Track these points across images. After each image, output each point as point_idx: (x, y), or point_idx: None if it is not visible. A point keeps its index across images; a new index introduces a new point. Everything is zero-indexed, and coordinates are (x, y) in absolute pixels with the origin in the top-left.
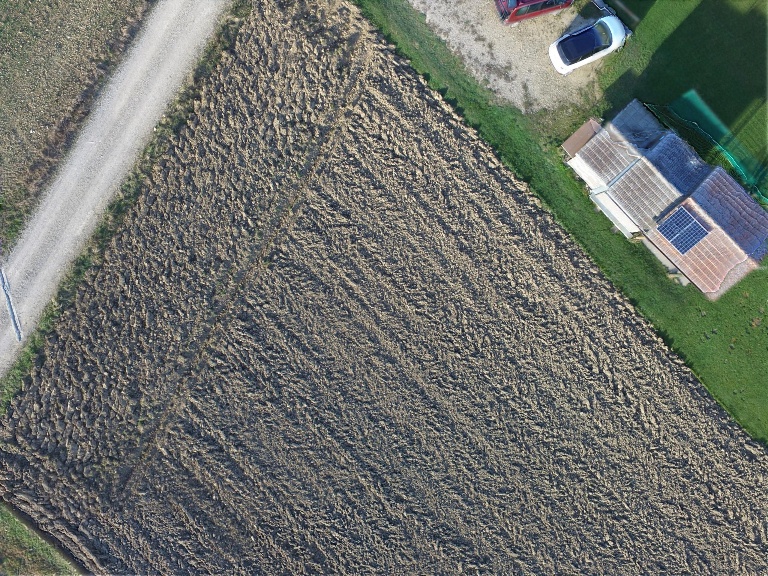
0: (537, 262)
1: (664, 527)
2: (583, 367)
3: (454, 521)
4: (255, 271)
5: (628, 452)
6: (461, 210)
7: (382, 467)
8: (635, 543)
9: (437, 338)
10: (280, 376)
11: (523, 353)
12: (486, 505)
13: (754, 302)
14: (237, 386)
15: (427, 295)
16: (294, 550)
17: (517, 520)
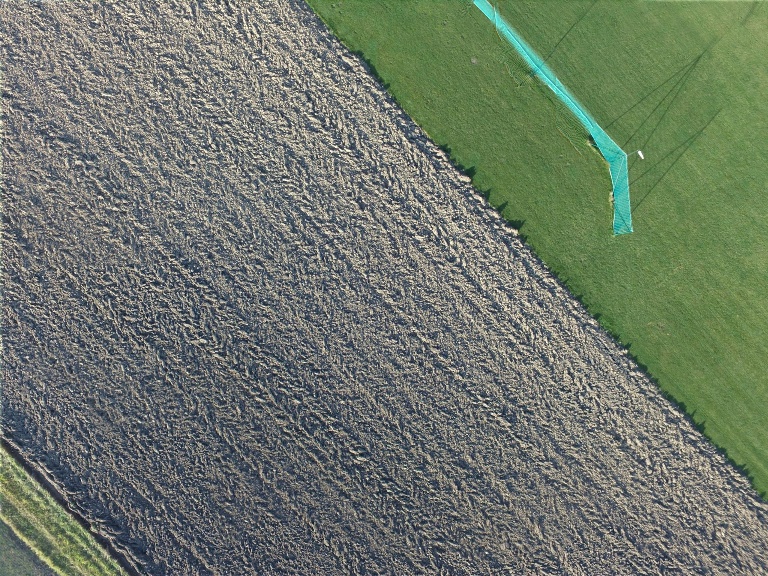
0: None
1: (265, 133)
2: None
3: (62, 120)
4: None
5: (231, 61)
6: None
7: None
8: (238, 148)
9: None
10: None
11: None
12: (93, 106)
13: None
14: None
15: None
16: None
17: (123, 121)
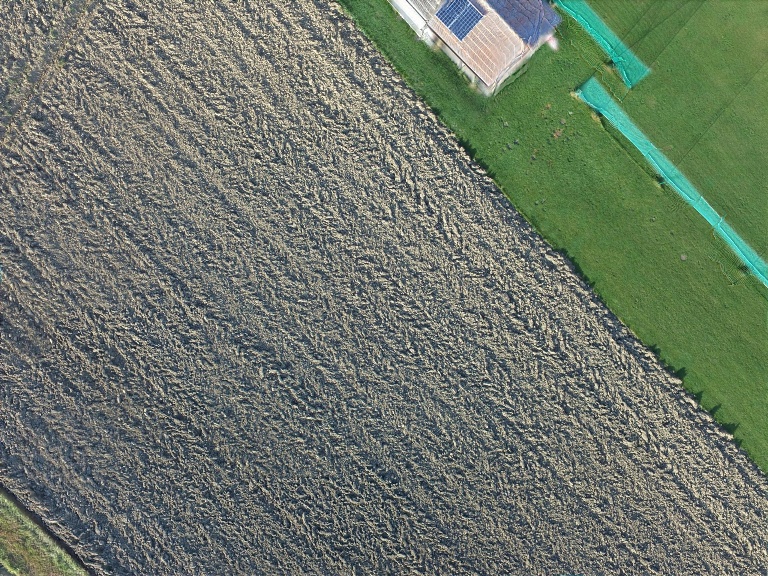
0: (338, 68)
1: (465, 336)
2: (385, 176)
3: (256, 327)
4: (50, 71)
5: (430, 261)
6: (261, 14)
7: (183, 272)
8: (437, 351)
9: (237, 143)
10: (77, 178)
11: (325, 161)
12: (288, 312)
13: (555, 113)
14: (33, 187)
15: (227, 99)
16: (93, 353)
17: (319, 327)
